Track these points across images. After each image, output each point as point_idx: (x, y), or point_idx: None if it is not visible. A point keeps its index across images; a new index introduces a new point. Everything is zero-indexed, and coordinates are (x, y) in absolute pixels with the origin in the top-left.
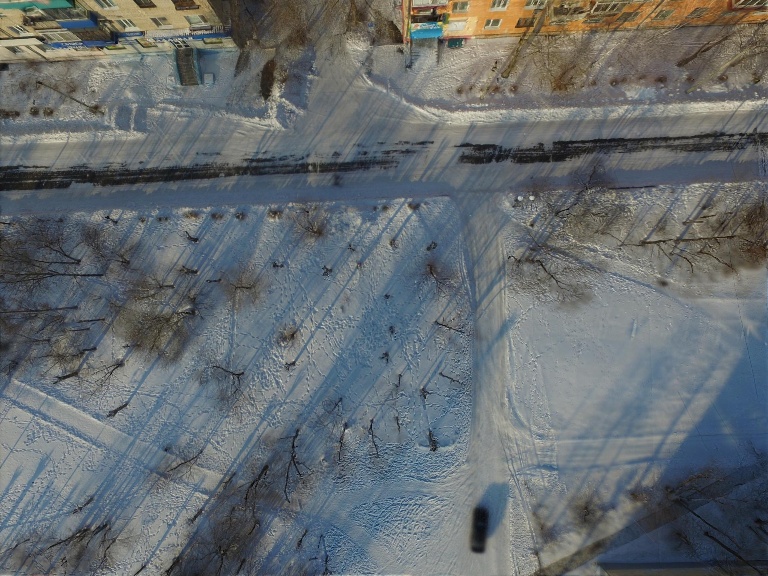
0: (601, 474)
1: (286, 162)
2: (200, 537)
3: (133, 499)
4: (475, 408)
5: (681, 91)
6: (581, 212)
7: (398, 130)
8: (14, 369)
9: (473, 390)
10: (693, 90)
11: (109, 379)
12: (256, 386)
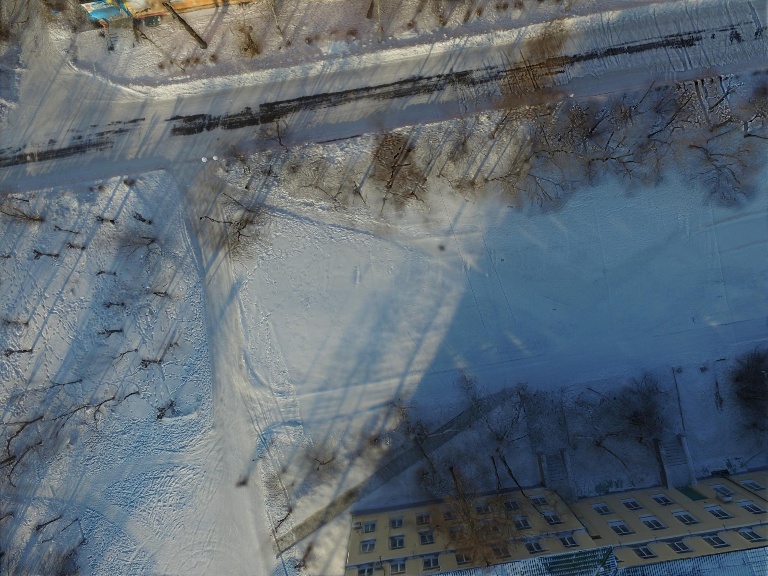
0: (345, 423)
1: (4, 155)
2: None
3: None
4: (215, 373)
5: (374, 41)
6: (292, 169)
7: (109, 111)
8: None
9: (210, 356)
10: (384, 39)
11: None
12: None
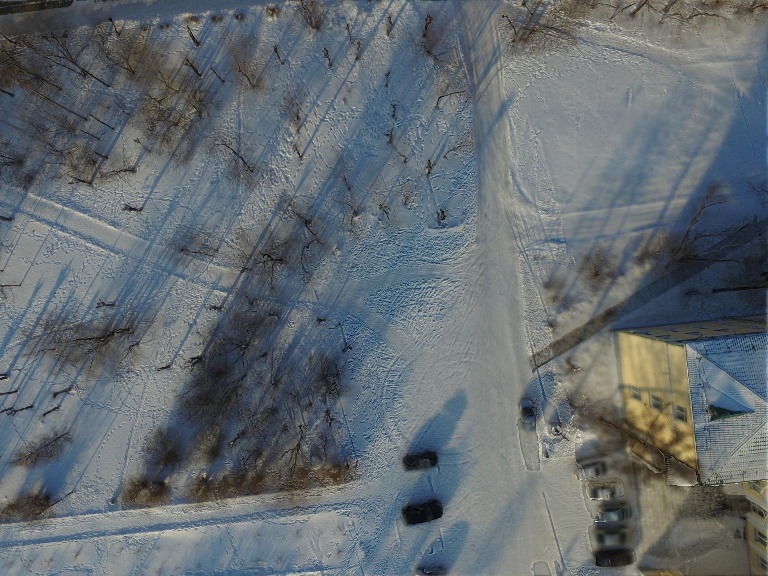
0: (608, 243)
1: None
2: (221, 330)
3: (153, 302)
4: (480, 189)
5: None
6: None
7: None
8: (29, 183)
9: (477, 171)
10: None
11: (122, 186)
12: (266, 183)
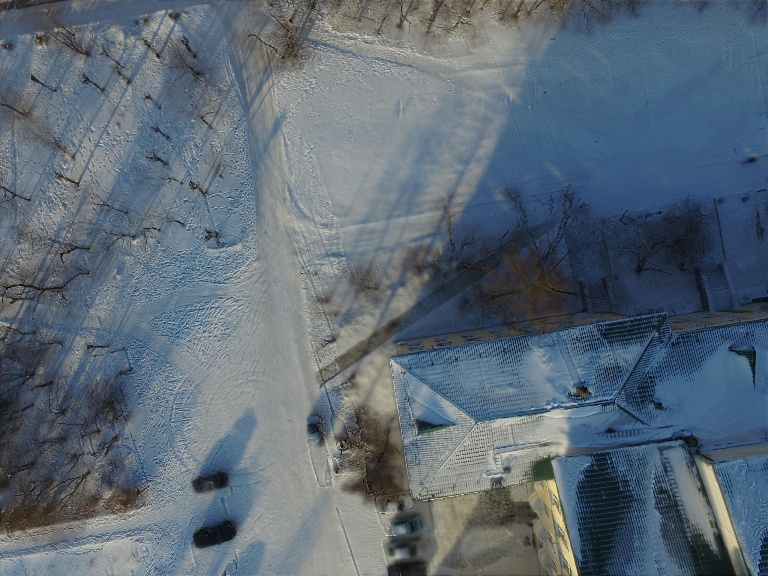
0: (388, 255)
1: None
2: (2, 362)
3: None
4: (259, 206)
5: None
6: (336, 2)
7: None
8: None
9: (255, 189)
10: None
11: None
12: (44, 211)
